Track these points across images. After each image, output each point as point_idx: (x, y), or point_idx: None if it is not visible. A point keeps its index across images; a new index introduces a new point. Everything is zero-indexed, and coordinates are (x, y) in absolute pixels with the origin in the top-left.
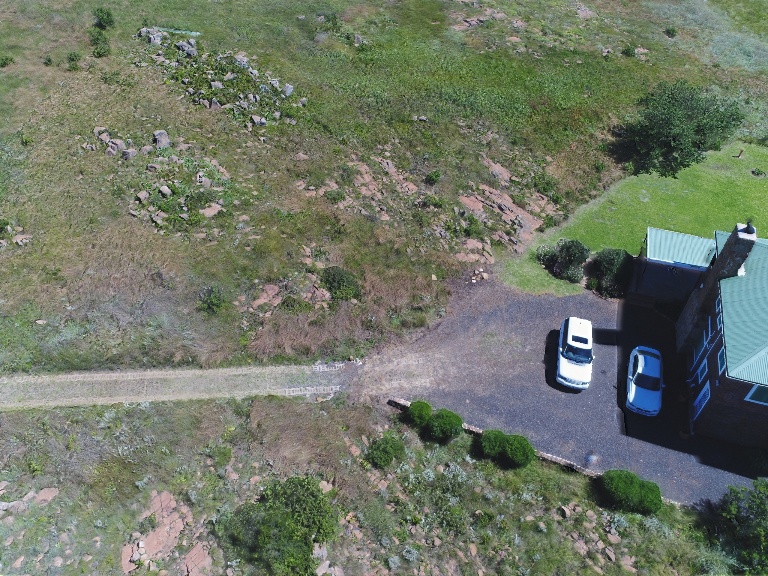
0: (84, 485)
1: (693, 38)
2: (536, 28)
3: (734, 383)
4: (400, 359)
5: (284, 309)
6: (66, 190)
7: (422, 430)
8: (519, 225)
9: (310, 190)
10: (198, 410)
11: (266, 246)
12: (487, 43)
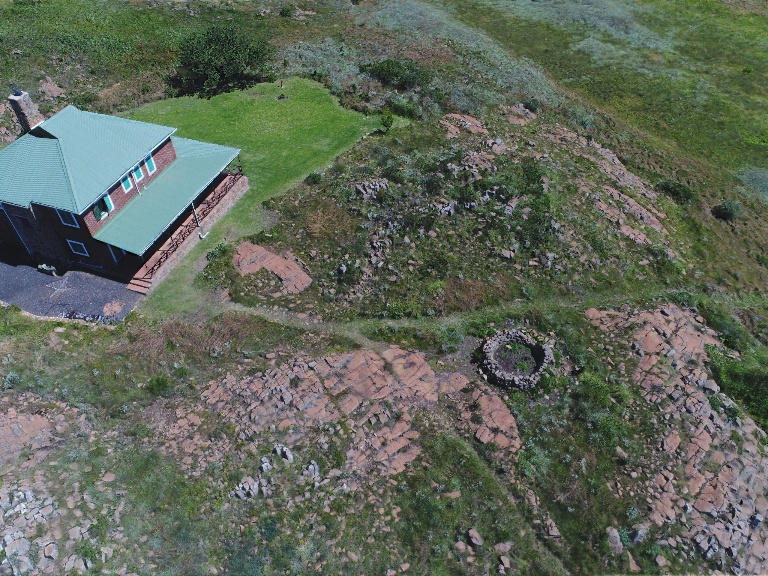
0: None
1: (372, 5)
2: None
3: None
4: None
5: None
6: None
7: None
8: None
9: None
10: None
11: None
12: (149, 2)
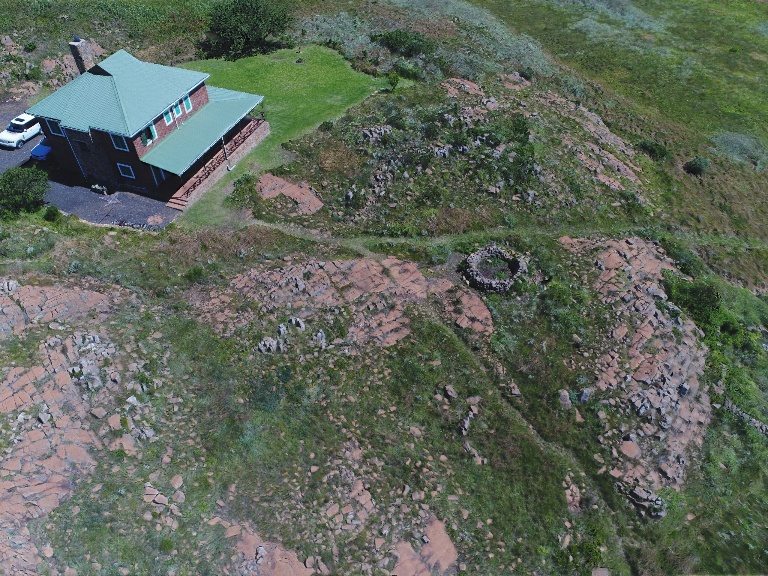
0: None
1: None
2: None
3: (39, 121)
4: None
5: None
6: None
7: None
8: (71, 76)
9: None
10: None
11: None
12: None
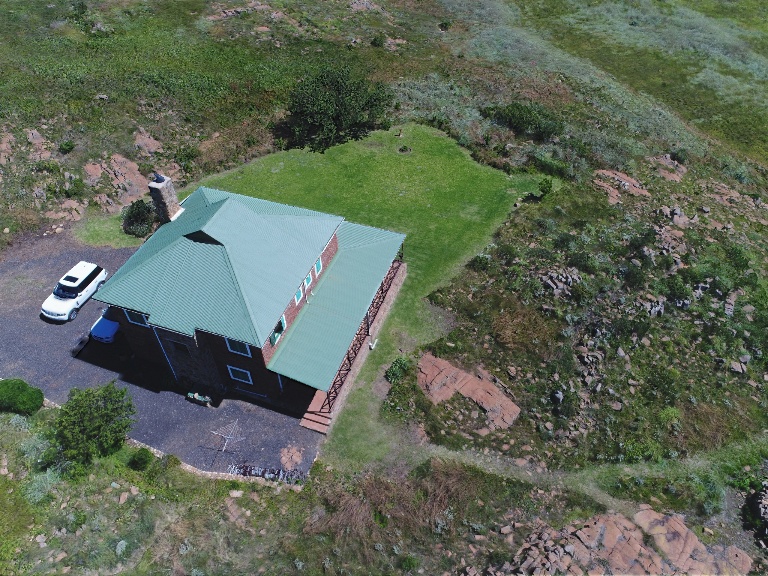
0: None
1: (463, 31)
2: (294, 19)
3: (112, 306)
4: None
5: None
6: None
7: None
8: (124, 189)
9: None
10: None
11: None
12: (231, 32)
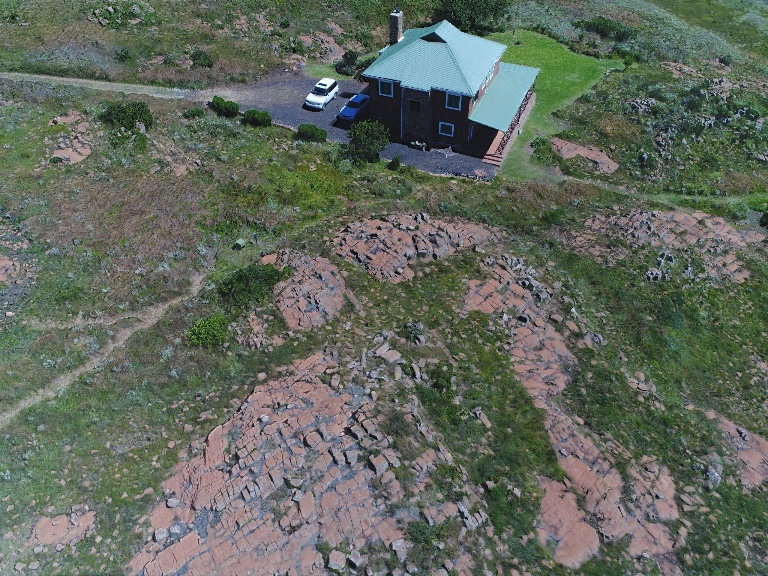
0: (37, 103)
1: None
2: None
3: (371, 82)
4: (223, 91)
5: (164, 65)
6: (53, 6)
7: (219, 112)
8: (330, 50)
9: (204, 24)
10: (101, 90)
11: (162, 38)
12: None
